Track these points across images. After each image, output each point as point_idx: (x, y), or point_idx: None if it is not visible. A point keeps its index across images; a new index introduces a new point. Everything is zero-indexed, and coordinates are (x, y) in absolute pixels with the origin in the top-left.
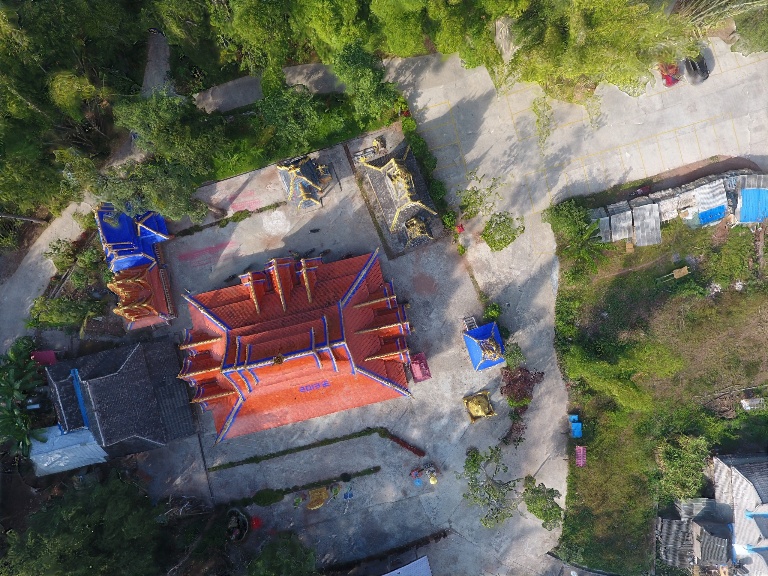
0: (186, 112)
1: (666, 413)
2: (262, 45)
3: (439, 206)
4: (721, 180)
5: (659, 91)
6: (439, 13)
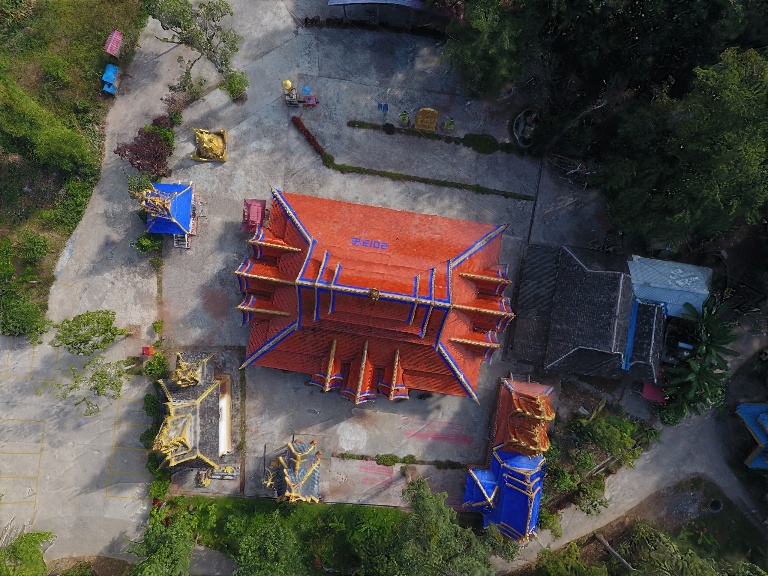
0: None
1: (2, 50)
2: None
3: None
4: None
5: None
6: None
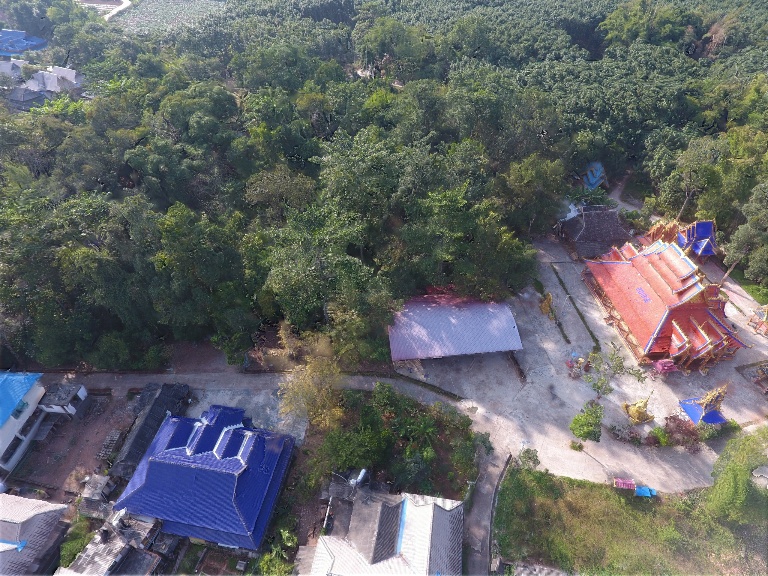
0: None
1: None
2: None
3: None
4: None
5: None
6: None
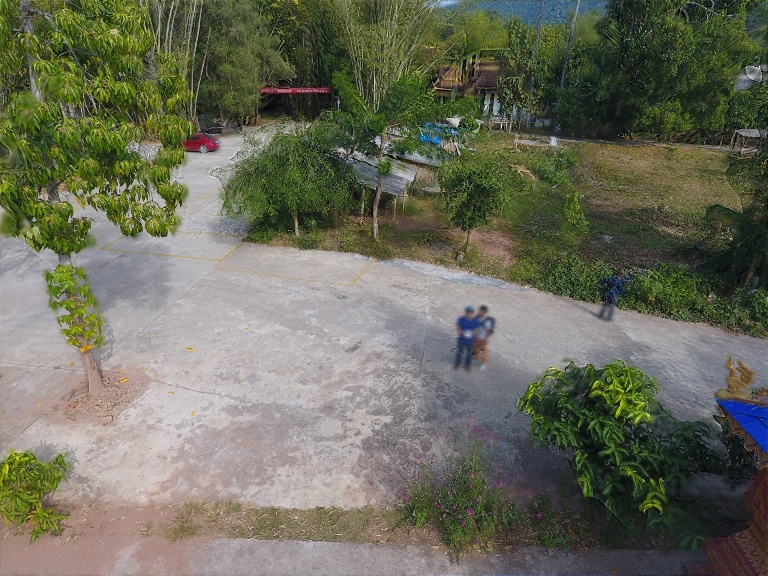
0: None
1: None
2: None
3: None
4: None
5: (210, 154)
6: None
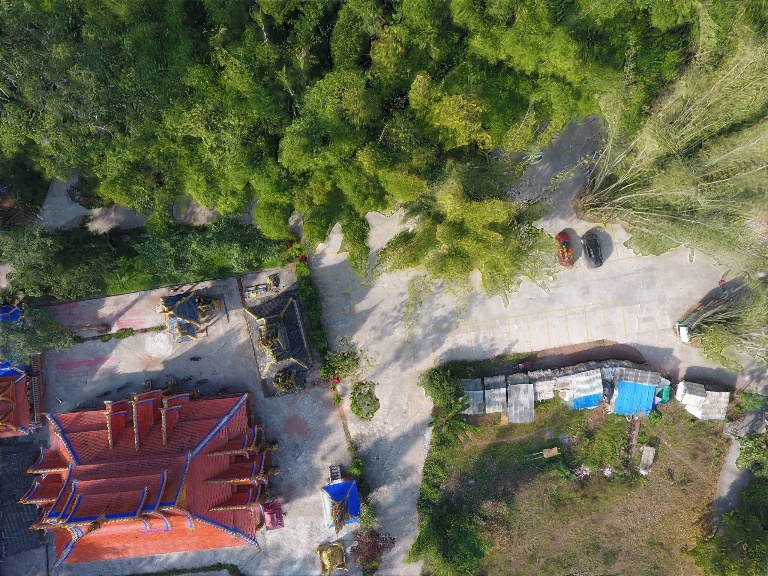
0: (68, 242)
1: None
2: (150, 191)
3: (320, 353)
4: (599, 370)
5: None
6: (304, 209)
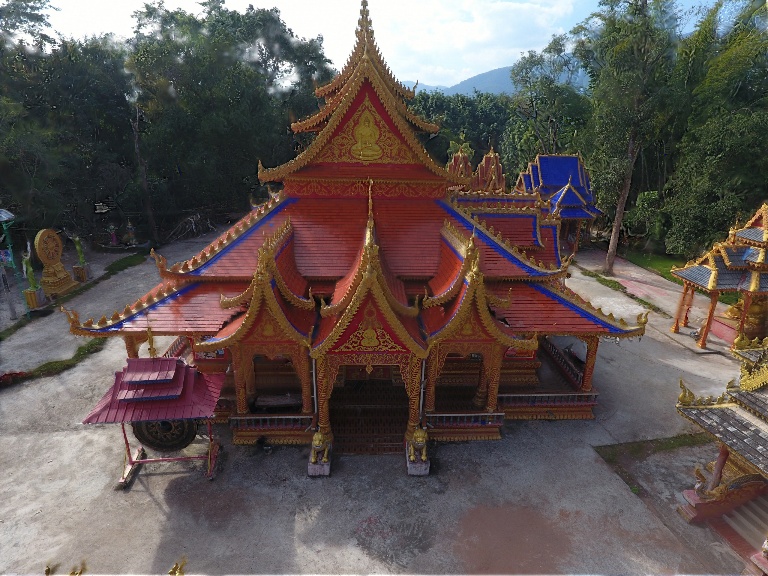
0: None
1: None
2: None
3: None
4: None
5: None
6: None
